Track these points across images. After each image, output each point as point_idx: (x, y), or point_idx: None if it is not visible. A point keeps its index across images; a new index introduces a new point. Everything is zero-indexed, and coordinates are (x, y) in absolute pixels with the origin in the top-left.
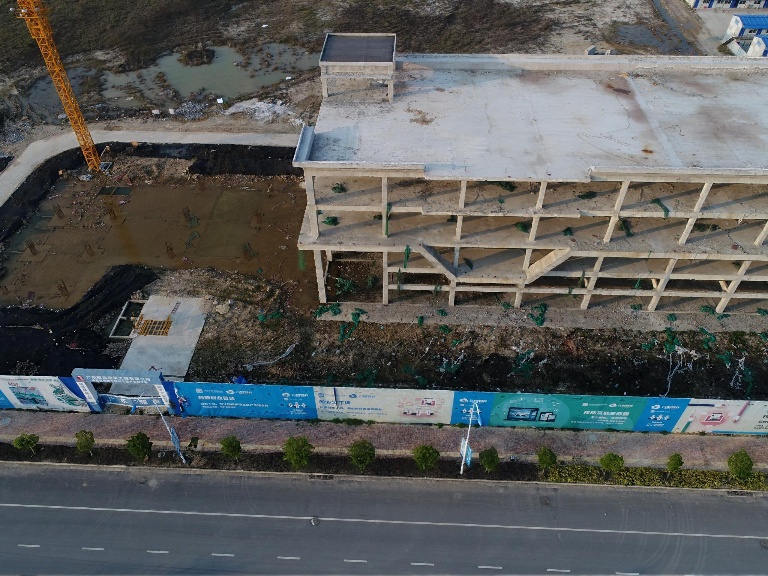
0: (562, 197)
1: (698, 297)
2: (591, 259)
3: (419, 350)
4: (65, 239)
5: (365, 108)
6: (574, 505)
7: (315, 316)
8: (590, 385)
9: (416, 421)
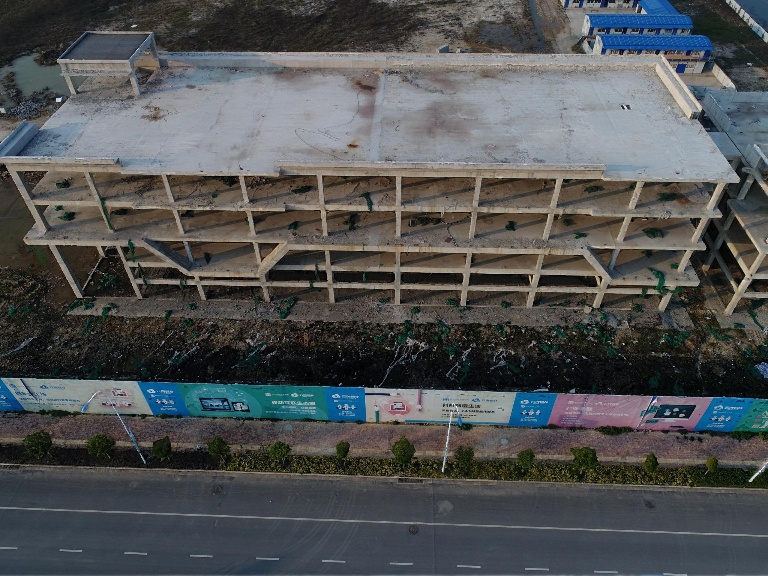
0: (276, 191)
1: (449, 290)
2: None
3: (155, 343)
4: None
5: (106, 105)
6: (243, 493)
7: (66, 310)
8: (308, 376)
9: (120, 412)
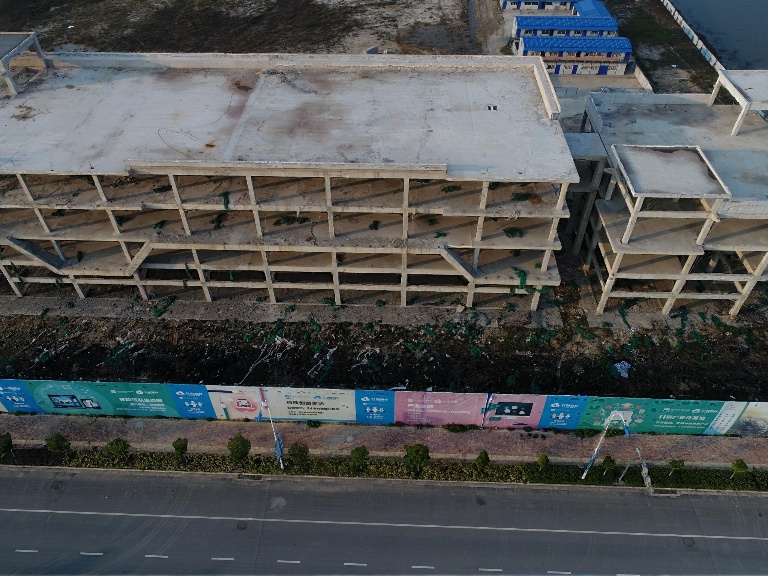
0: (137, 191)
1: (328, 289)
2: (201, 252)
3: (26, 341)
4: None
5: None
6: (82, 489)
7: None
8: (170, 374)
9: None
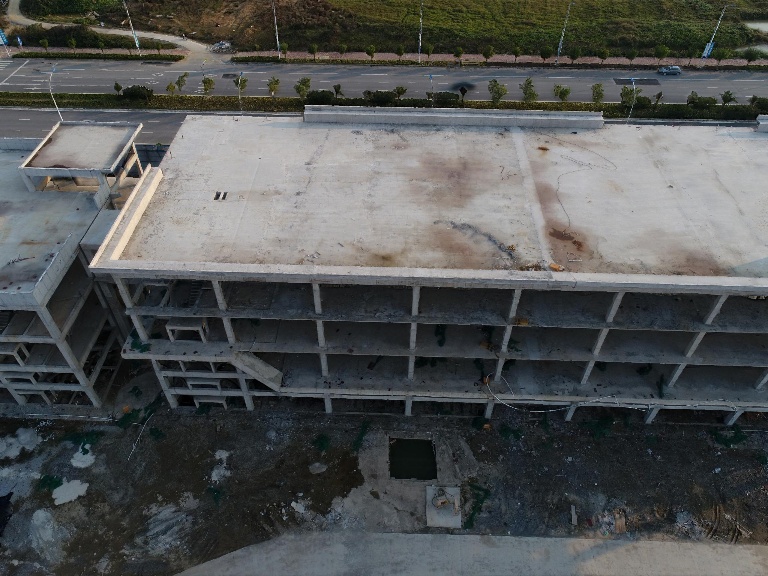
0: None
1: None
2: None
3: None
4: None
5: None
6: None
7: None
8: None
9: None
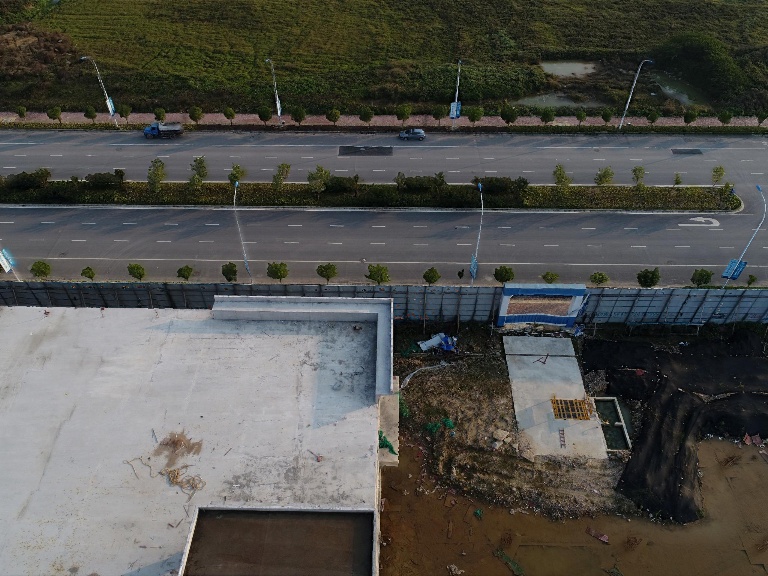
0: None
1: None
2: None
3: None
4: None
5: (282, 493)
6: None
7: None
8: None
9: None
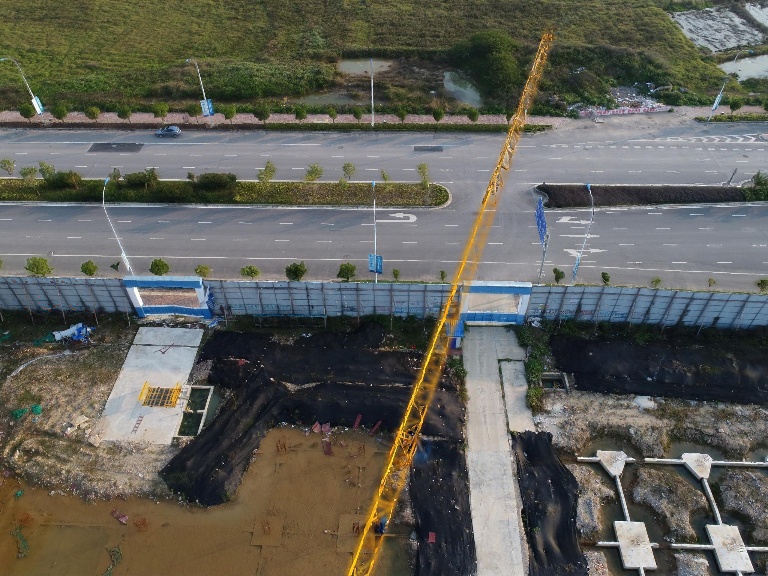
0: None
1: None
2: None
3: None
4: (321, 568)
5: None
6: None
7: None
8: None
9: None
